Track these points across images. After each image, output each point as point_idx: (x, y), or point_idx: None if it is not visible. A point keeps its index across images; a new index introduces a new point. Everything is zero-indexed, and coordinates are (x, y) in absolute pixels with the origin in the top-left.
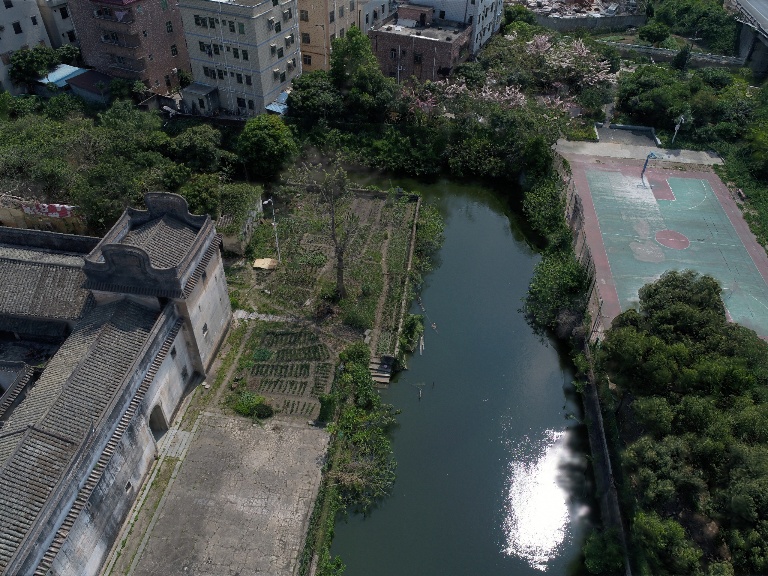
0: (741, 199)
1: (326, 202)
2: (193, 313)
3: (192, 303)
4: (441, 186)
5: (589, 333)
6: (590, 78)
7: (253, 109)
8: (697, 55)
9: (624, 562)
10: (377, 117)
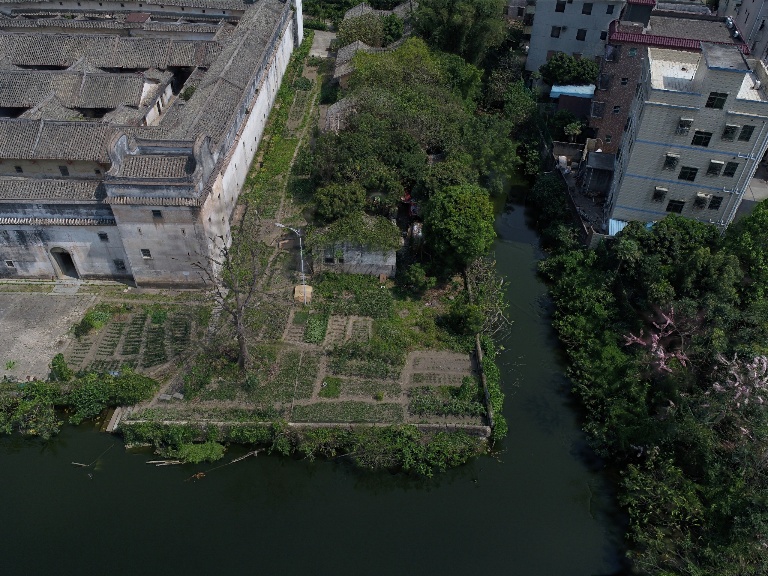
0: None
1: (441, 324)
2: (126, 226)
3: (126, 218)
4: None
5: None
6: None
7: None
8: None
9: None
10: None
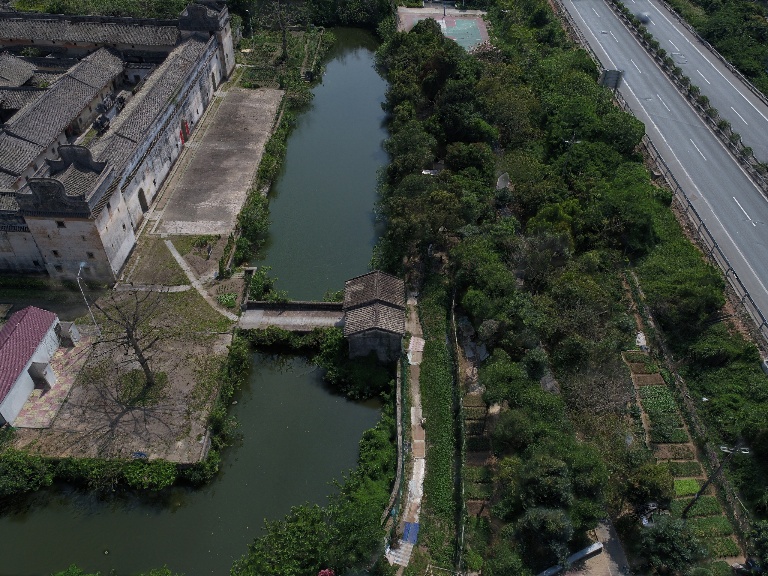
0: (489, 25)
1: None
2: (223, 42)
3: None
4: (337, 31)
5: None
6: None
7: None
8: None
9: None
10: None
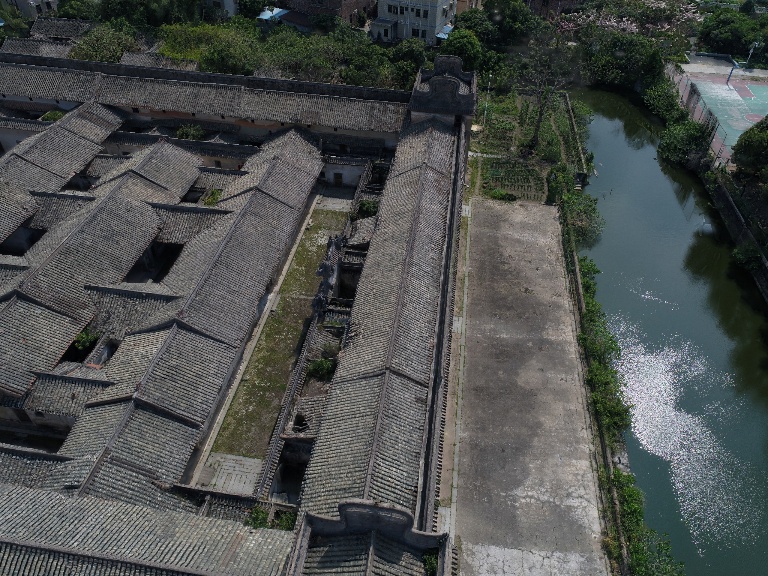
0: None
1: None
2: None
3: None
4: (572, 93)
5: (714, 160)
6: (681, 16)
7: (425, 37)
8: (755, 8)
9: (761, 254)
10: (524, 41)
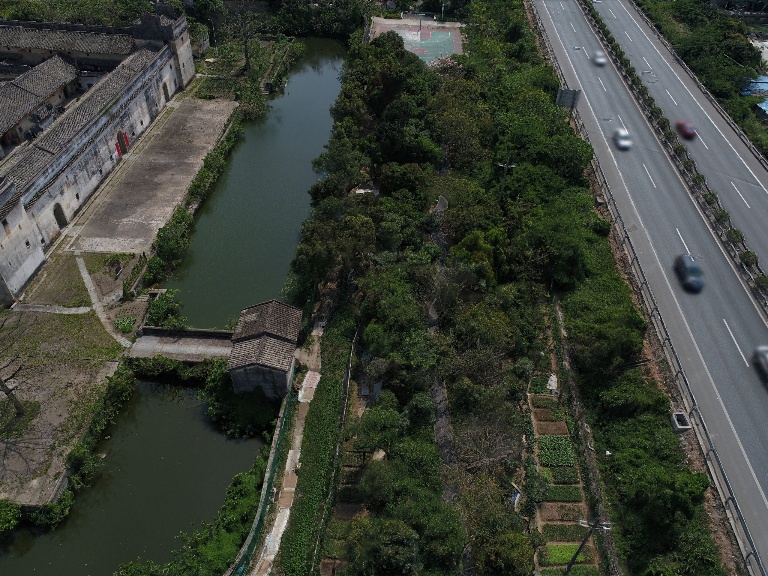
0: (465, 38)
1: None
2: (178, 52)
3: (178, 47)
4: (311, 41)
5: None
6: None
7: None
8: None
9: None
10: (273, 4)
